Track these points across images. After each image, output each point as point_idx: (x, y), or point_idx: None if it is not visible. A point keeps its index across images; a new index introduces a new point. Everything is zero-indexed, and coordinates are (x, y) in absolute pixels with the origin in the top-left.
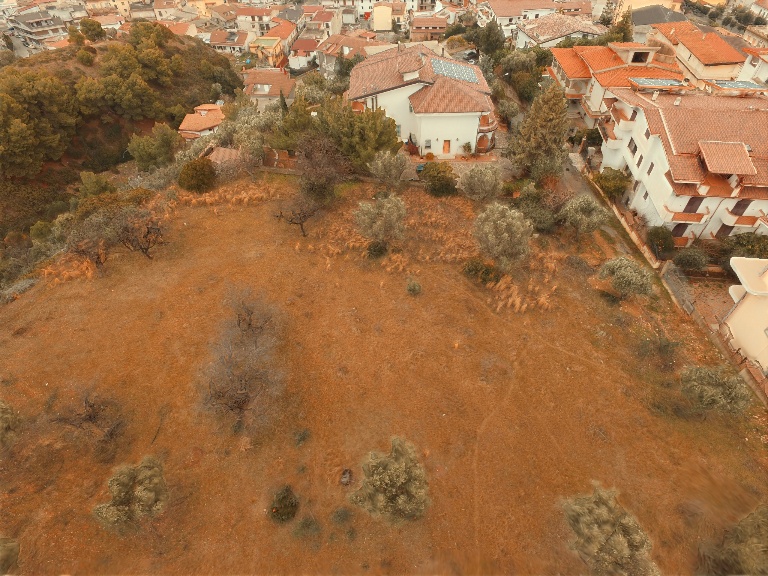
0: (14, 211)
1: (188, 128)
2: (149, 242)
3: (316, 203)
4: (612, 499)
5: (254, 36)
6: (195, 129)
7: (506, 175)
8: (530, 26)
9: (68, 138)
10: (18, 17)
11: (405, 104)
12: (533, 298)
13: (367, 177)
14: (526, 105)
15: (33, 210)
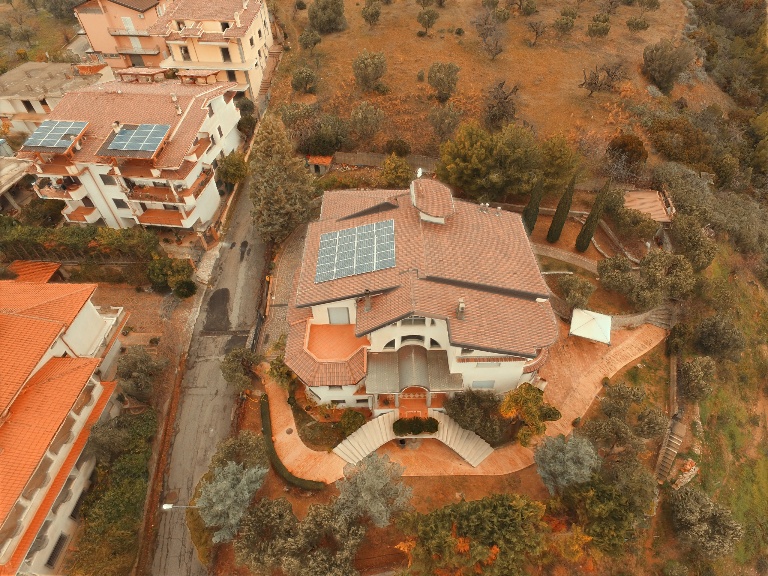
0: None
1: None
2: None
3: None
4: (368, 10)
5: None
6: None
7: None
8: None
9: None
10: None
11: None
12: None
13: None
14: None
15: None
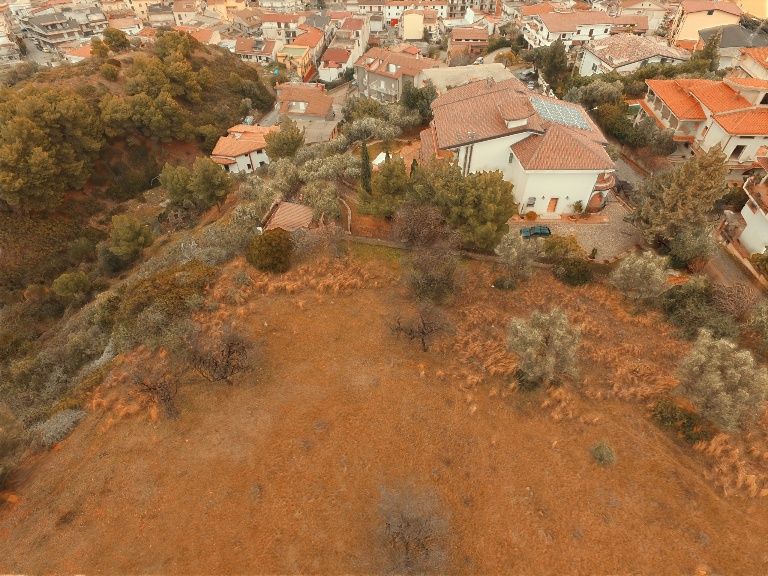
0: (33, 251)
1: (222, 153)
2: (232, 368)
3: (433, 301)
4: None
5: (281, 44)
6: (230, 154)
7: (627, 243)
8: (600, 47)
9: (91, 164)
10: (32, 19)
11: (505, 154)
12: (762, 468)
13: (477, 254)
14: (614, 143)
15: (54, 249)
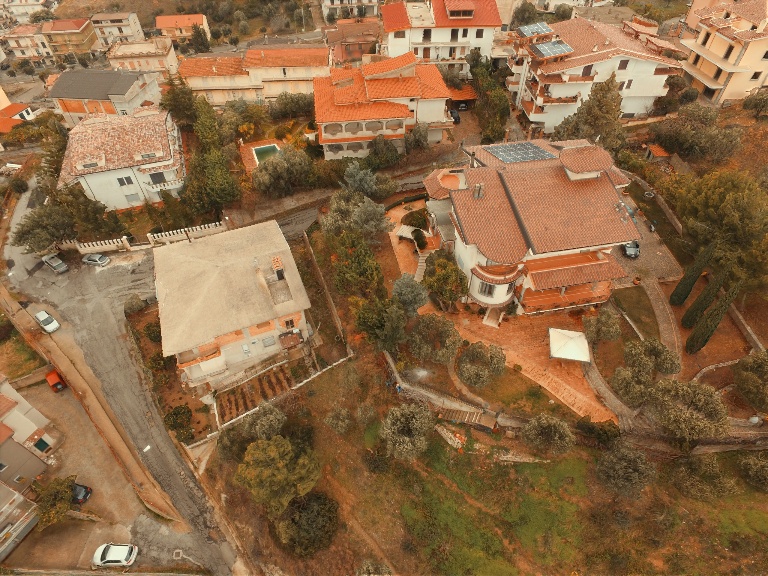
0: None
1: None
2: None
3: None
4: None
5: None
6: None
7: None
8: None
9: None
10: None
11: None
12: None
13: None
14: None
15: None
